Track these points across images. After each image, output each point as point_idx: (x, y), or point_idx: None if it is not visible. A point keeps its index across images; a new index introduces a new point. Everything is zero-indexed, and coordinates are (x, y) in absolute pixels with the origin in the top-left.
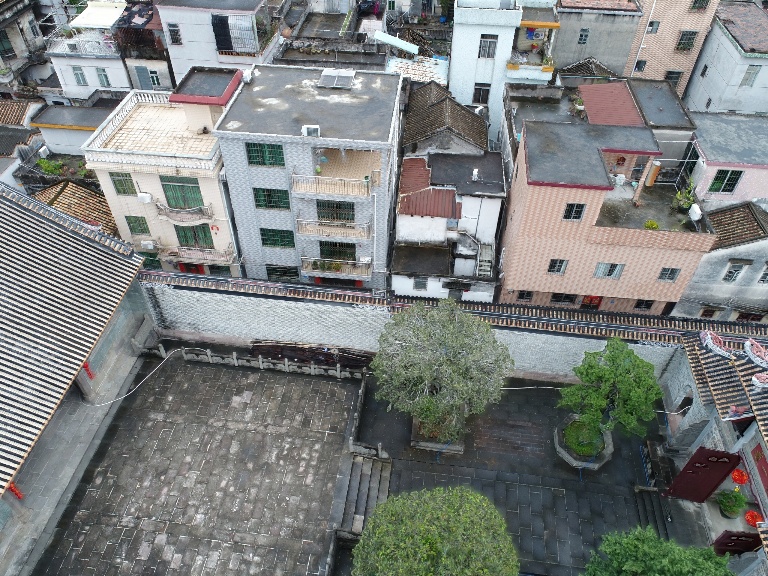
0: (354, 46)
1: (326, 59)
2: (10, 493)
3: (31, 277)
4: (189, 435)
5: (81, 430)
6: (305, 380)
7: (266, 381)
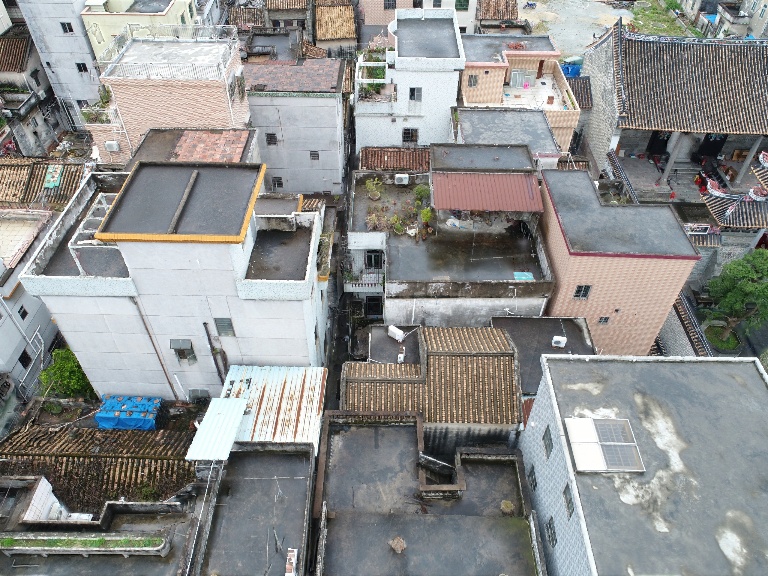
0: (209, 514)
1: (251, 575)
2: None
3: None
4: None
5: None
6: None
7: None
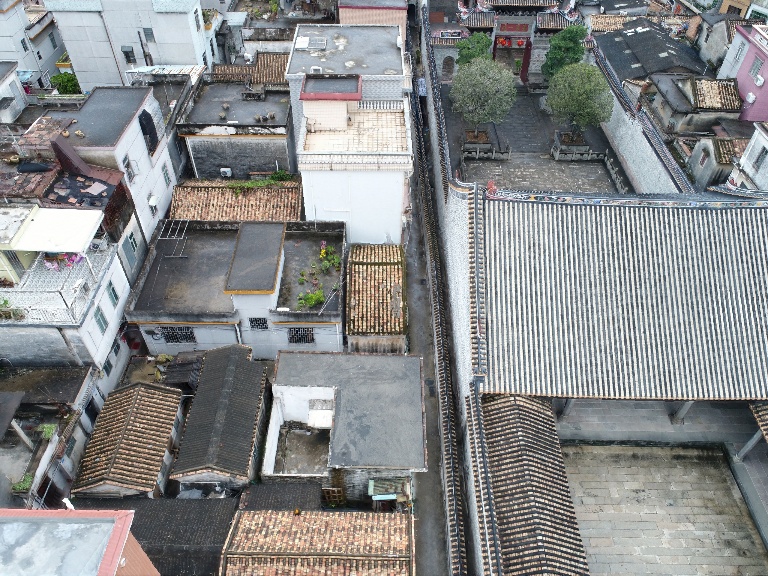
0: None
1: None
2: None
3: None
4: None
5: None
6: (469, 179)
7: None
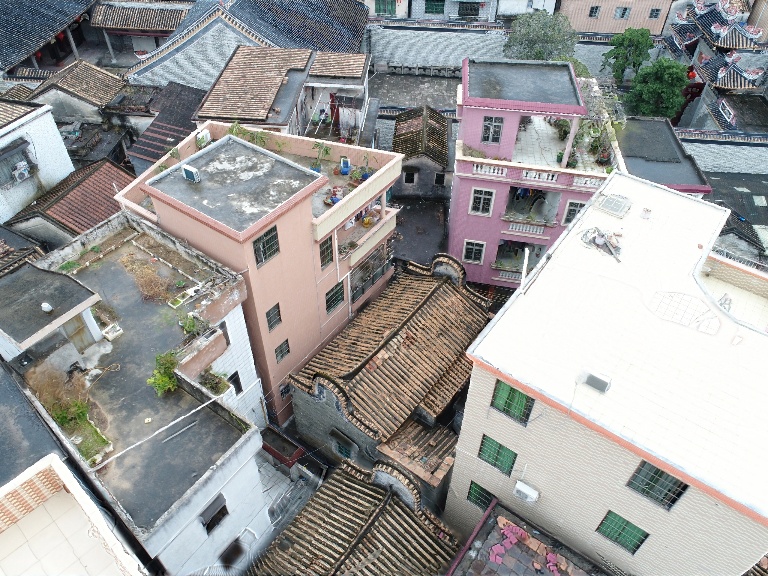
0: None
1: None
2: None
3: (328, 2)
4: (403, 96)
5: None
6: (457, 80)
7: (435, 80)
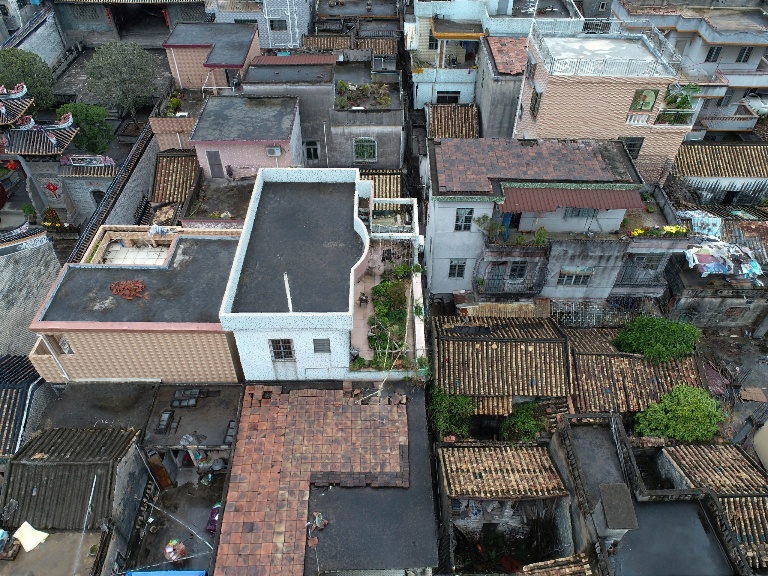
0: None
1: None
2: (114, 23)
3: None
4: None
5: (157, 42)
6: None
7: None
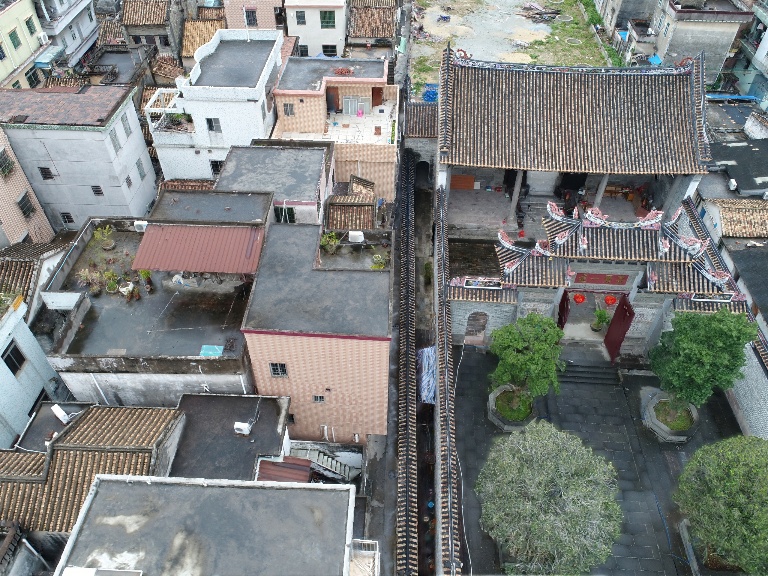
0: None
1: None
2: None
3: None
4: None
5: None
6: None
7: None
